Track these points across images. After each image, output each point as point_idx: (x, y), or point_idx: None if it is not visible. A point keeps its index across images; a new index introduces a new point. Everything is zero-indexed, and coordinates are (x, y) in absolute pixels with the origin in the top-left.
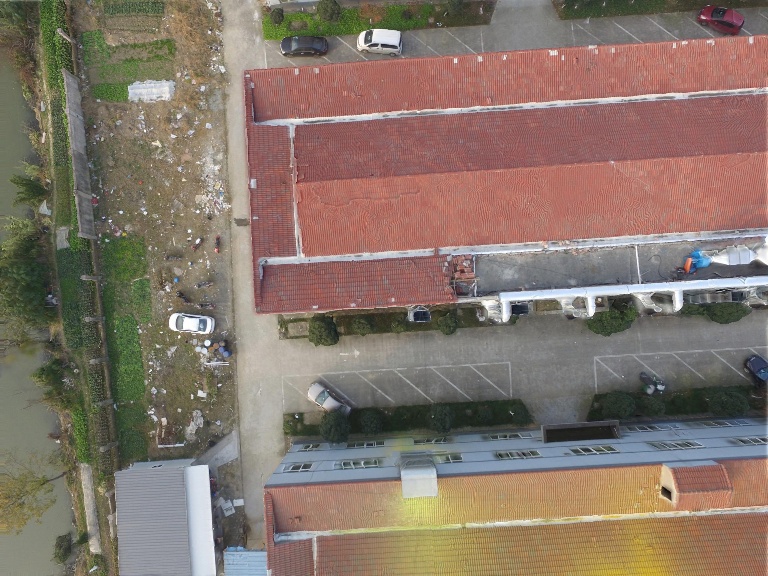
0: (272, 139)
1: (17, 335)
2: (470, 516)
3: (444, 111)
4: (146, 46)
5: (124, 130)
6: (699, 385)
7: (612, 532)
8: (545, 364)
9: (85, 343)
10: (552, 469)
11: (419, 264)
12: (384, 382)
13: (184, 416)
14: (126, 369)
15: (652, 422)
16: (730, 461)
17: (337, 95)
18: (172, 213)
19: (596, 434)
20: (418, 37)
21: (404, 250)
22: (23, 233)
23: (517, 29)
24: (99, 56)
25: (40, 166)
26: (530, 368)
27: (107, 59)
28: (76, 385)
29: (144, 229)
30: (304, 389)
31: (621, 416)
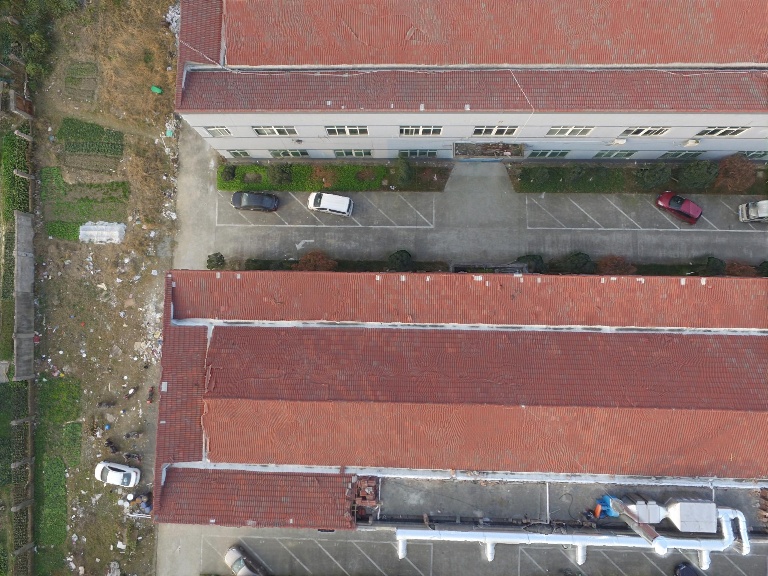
0: (188, 340)
1: None
2: None
3: (364, 323)
4: (102, 187)
5: (72, 270)
6: None
7: None
8: (468, 549)
9: (13, 481)
10: None
11: (323, 483)
12: (303, 552)
13: (102, 566)
14: (50, 512)
15: None
16: None
17: (258, 298)
18: (110, 358)
19: None
20: (370, 199)
21: (310, 464)
22: None
23: (470, 199)
24: (56, 193)
25: None
26: (453, 552)
27: (63, 197)
28: (1, 522)
29: (81, 372)
30: (223, 551)
31: None
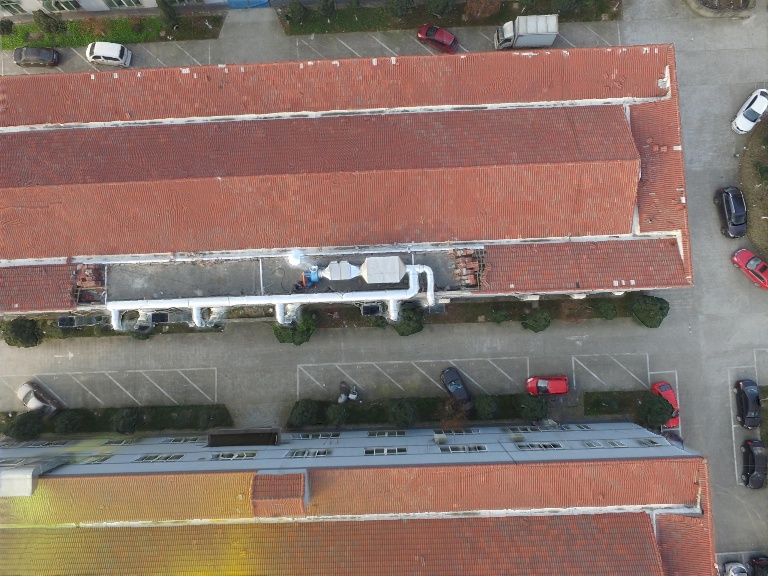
0: None
1: None
2: (72, 516)
3: (87, 125)
4: None
5: None
6: (398, 395)
7: (214, 536)
8: (250, 371)
9: None
10: (155, 473)
11: (50, 272)
12: (95, 384)
13: None
14: None
15: (321, 430)
16: (324, 470)
17: None
18: None
19: (251, 440)
20: (149, 50)
21: (41, 258)
22: None
23: (244, 44)
24: None
25: None
26: (235, 374)
27: None
28: None
29: None
30: None
31: (293, 424)
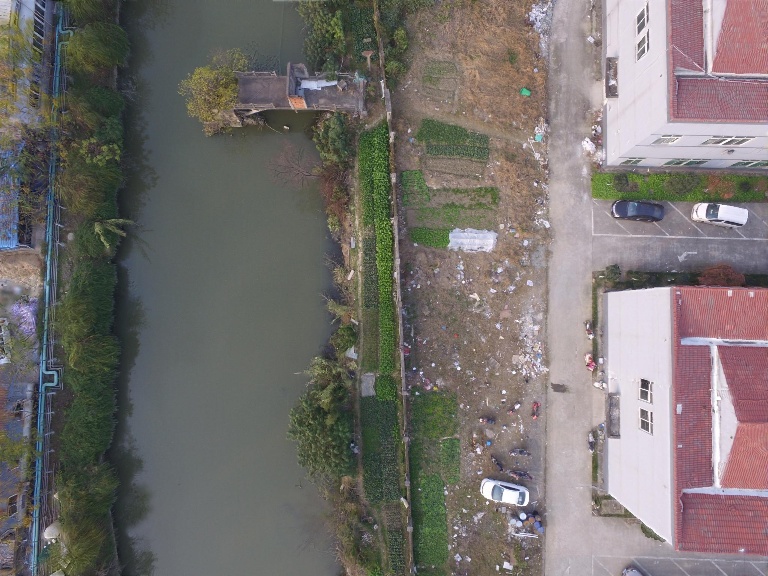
0: (696, 361)
1: (323, 487)
2: None
3: None
4: (468, 192)
5: (441, 279)
6: None
7: None
8: None
9: (386, 498)
10: None
11: None
12: (700, 572)
13: None
14: (430, 531)
15: None
16: None
17: (761, 317)
18: (487, 371)
19: None
20: (753, 210)
21: None
22: (335, 380)
23: None
24: (418, 198)
25: (344, 303)
26: None
27: (427, 202)
28: (374, 541)
29: (457, 385)
30: (615, 571)
31: None
